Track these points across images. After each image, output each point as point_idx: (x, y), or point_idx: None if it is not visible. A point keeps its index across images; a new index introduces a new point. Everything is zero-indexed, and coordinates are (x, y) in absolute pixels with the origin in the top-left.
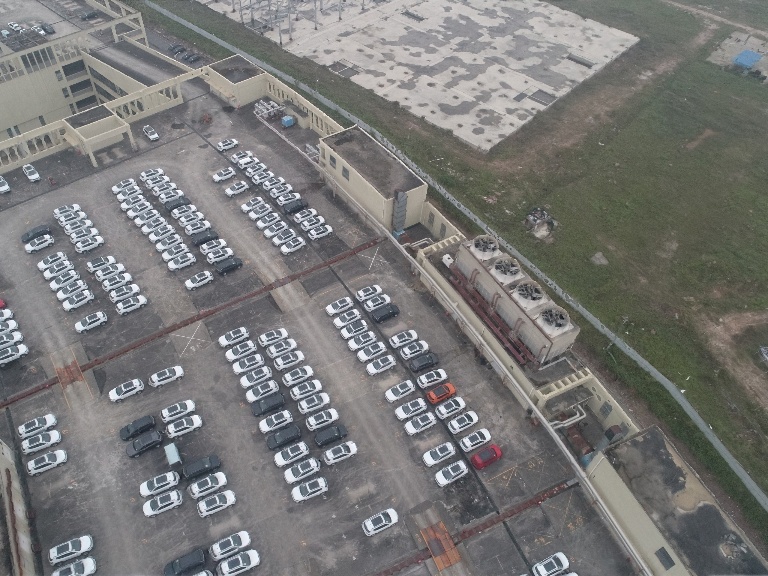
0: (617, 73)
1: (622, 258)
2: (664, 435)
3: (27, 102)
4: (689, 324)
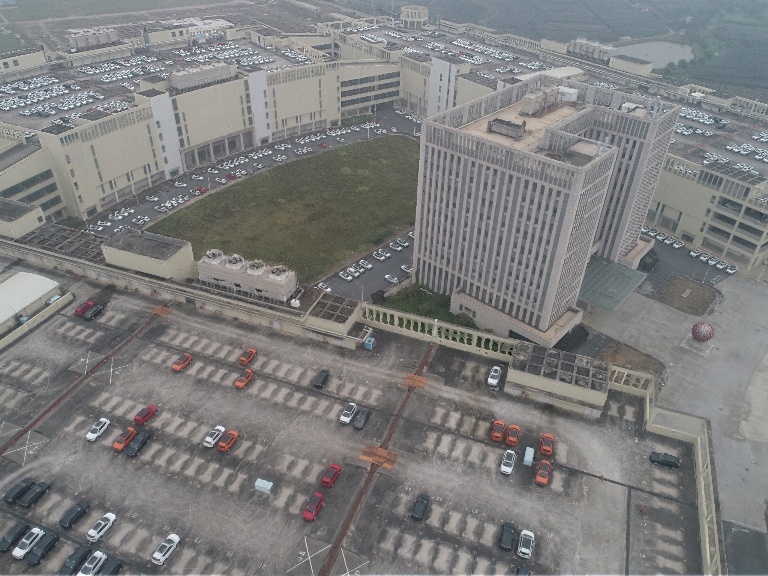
0: None
1: None
2: None
3: None
4: None
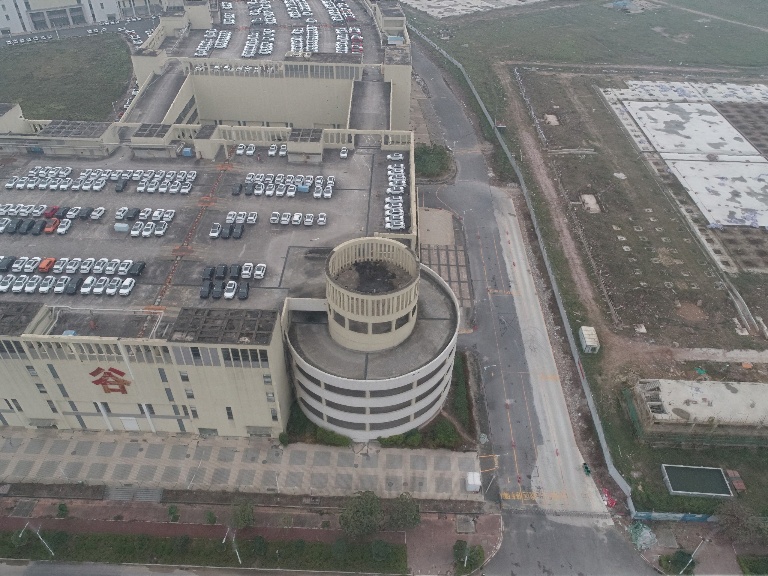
0: (539, 5)
1: (476, 46)
2: None
3: None
4: (488, 60)
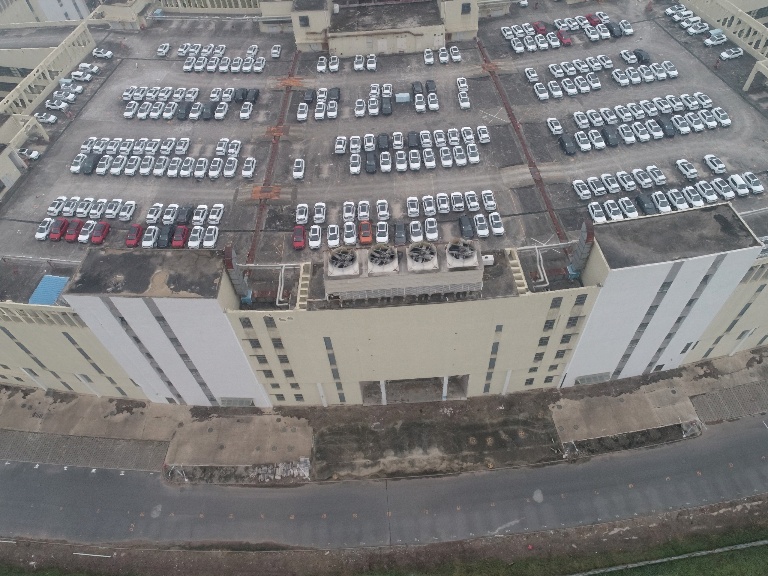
0: None
1: None
2: (205, 298)
3: None
4: None
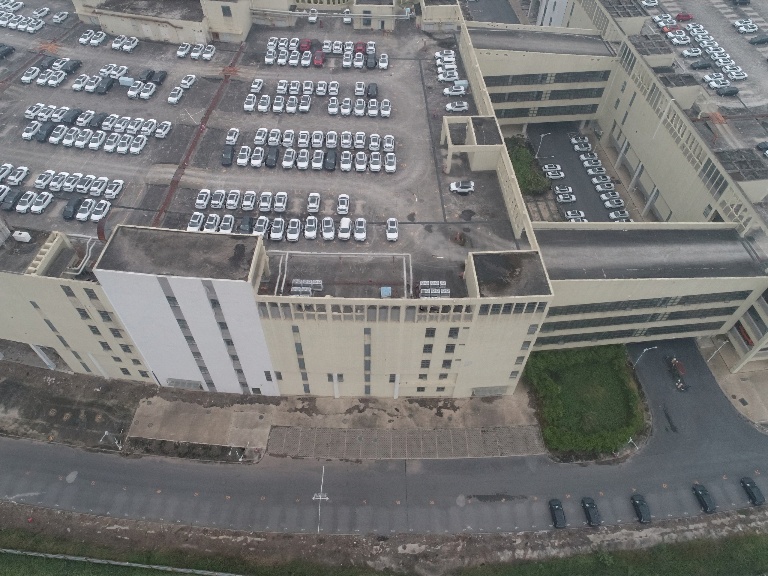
0: None
1: None
2: None
3: (678, 190)
4: None
